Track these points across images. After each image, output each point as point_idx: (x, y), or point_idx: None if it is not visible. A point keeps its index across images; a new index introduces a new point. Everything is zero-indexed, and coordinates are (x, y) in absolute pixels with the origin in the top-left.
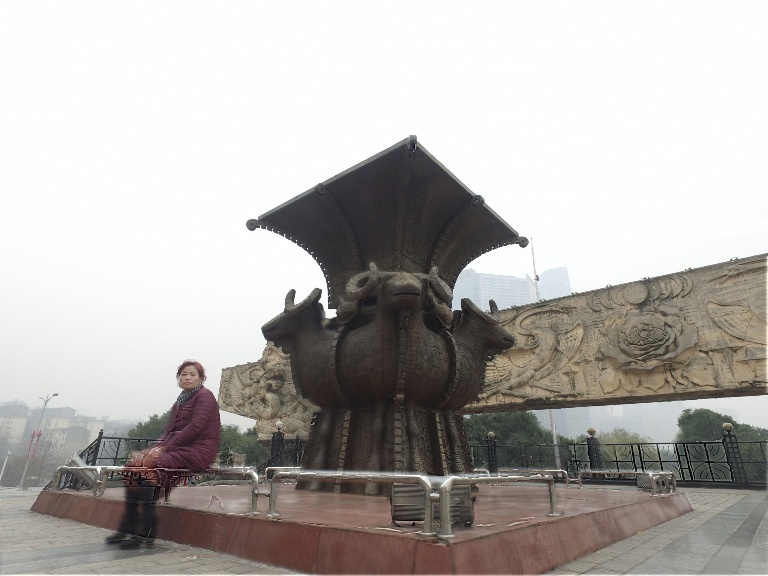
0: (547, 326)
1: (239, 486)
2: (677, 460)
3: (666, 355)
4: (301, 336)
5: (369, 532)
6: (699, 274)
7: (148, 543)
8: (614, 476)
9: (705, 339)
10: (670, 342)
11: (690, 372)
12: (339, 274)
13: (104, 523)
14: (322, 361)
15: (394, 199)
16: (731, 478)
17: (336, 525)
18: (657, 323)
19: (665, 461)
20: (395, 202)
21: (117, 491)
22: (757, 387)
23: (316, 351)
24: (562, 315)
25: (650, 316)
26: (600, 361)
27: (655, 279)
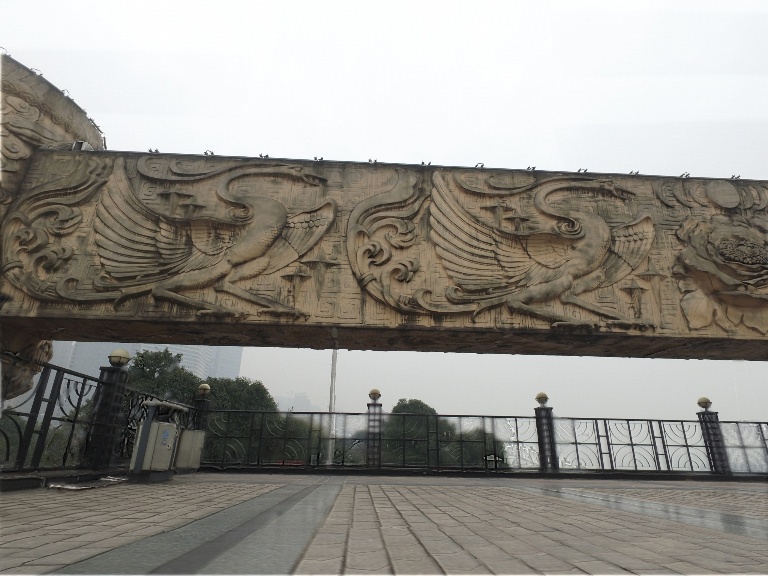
0: (591, 211)
1: None
2: (652, 443)
3: None
4: None
5: None
6: None
7: None
8: (572, 465)
9: None
10: None
11: None
12: None
13: None
14: None
15: None
16: (710, 467)
17: None
18: (756, 239)
19: (638, 444)
20: None
21: None
22: None
23: None
24: (615, 200)
25: (745, 228)
26: (681, 279)
27: (745, 182)
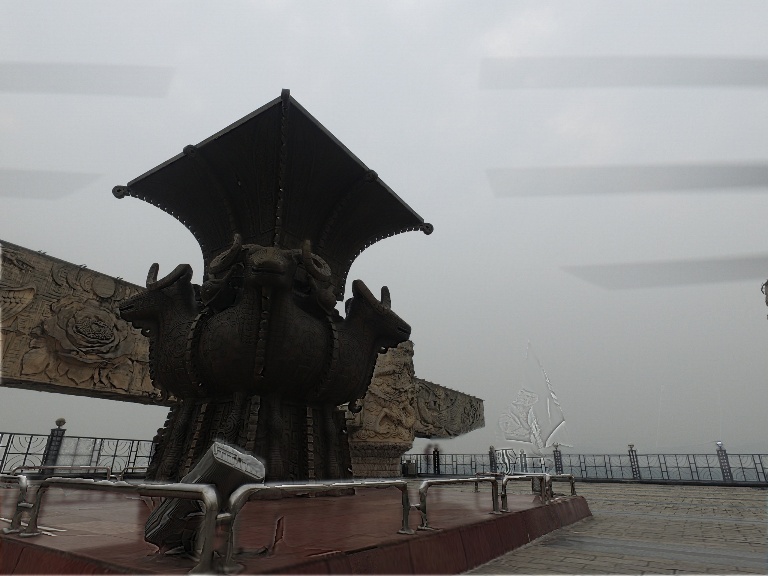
0: None
1: None
2: None
3: (108, 354)
4: (289, 298)
5: (576, 498)
6: None
7: None
8: None
9: (137, 350)
10: (115, 344)
11: (115, 374)
12: (292, 237)
13: (490, 553)
14: (313, 345)
15: (374, 231)
16: None
17: (561, 499)
18: (109, 322)
19: None
20: (372, 233)
21: None
22: (151, 397)
23: (307, 329)
24: (13, 268)
25: (106, 313)
26: (35, 338)
27: (125, 283)
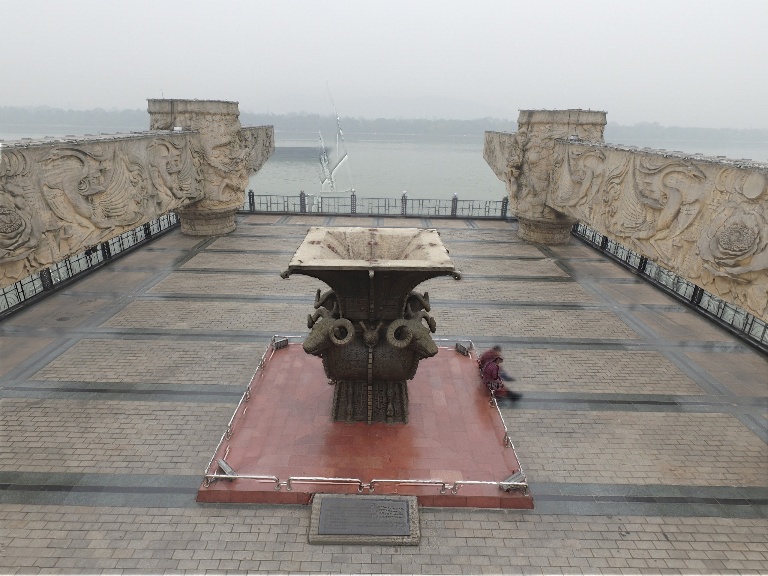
0: None
1: (404, 471)
2: None
3: (32, 242)
4: None
5: None
6: (32, 152)
7: (497, 401)
8: None
9: (42, 220)
10: None
11: (40, 254)
12: None
13: None
14: None
15: None
16: None
17: None
18: None
19: None
20: None
21: (493, 465)
22: None
23: None
24: None
25: (2, 196)
26: None
27: (0, 151)
